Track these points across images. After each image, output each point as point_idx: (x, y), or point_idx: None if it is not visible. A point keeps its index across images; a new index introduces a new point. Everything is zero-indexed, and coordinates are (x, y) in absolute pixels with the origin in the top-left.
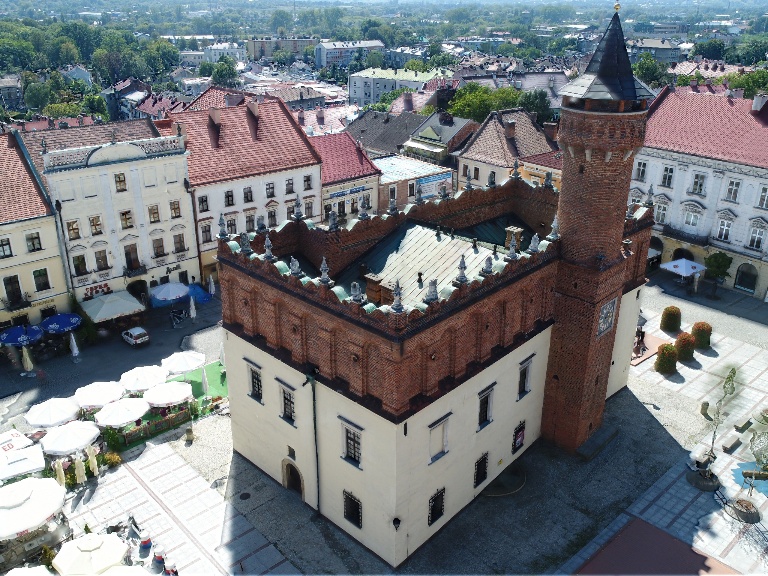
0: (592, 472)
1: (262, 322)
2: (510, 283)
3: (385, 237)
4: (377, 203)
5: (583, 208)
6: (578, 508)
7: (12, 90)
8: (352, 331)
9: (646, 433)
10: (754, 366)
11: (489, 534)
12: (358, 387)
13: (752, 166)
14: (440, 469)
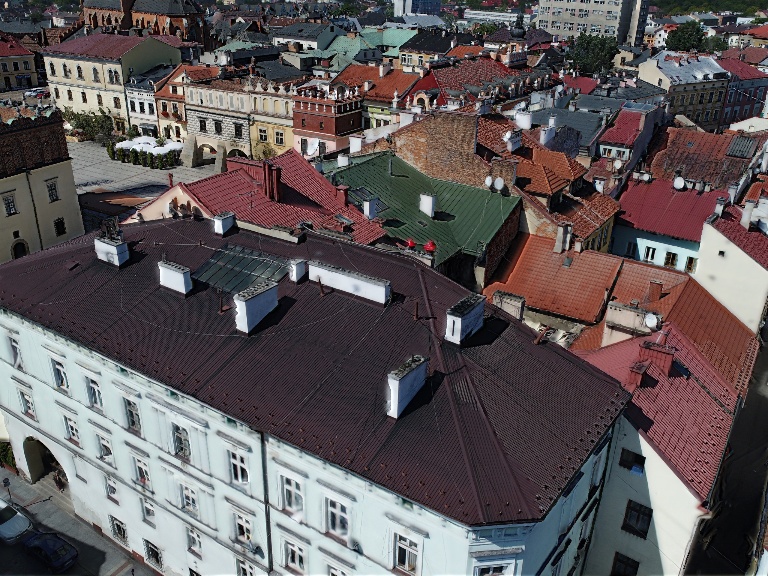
0: None
1: None
2: None
3: None
4: None
5: None
6: None
7: None
8: None
9: None
10: None
11: None
12: None
13: None
14: None
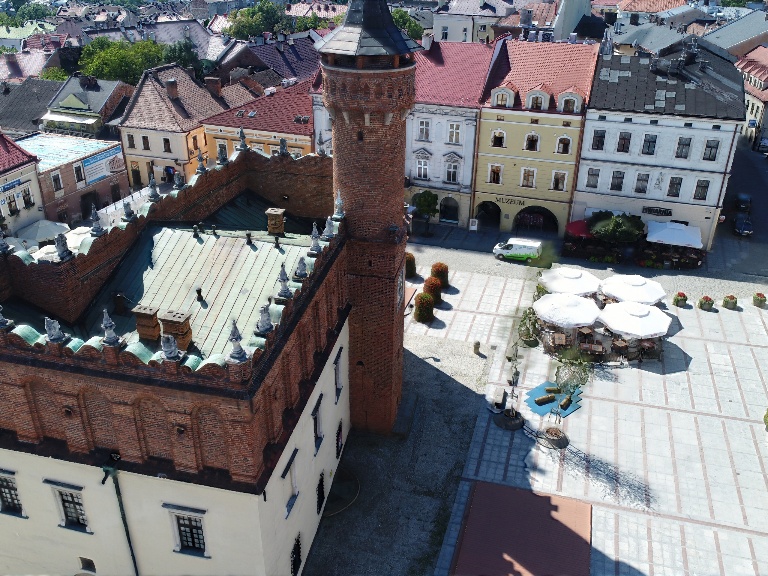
0: (415, 448)
1: (1, 412)
2: (321, 281)
3: (128, 251)
4: (40, 197)
5: (368, 179)
6: (421, 492)
7: None
8: (170, 397)
9: (441, 389)
10: (491, 294)
11: (352, 560)
12: (189, 463)
13: (439, 105)
14: (294, 516)
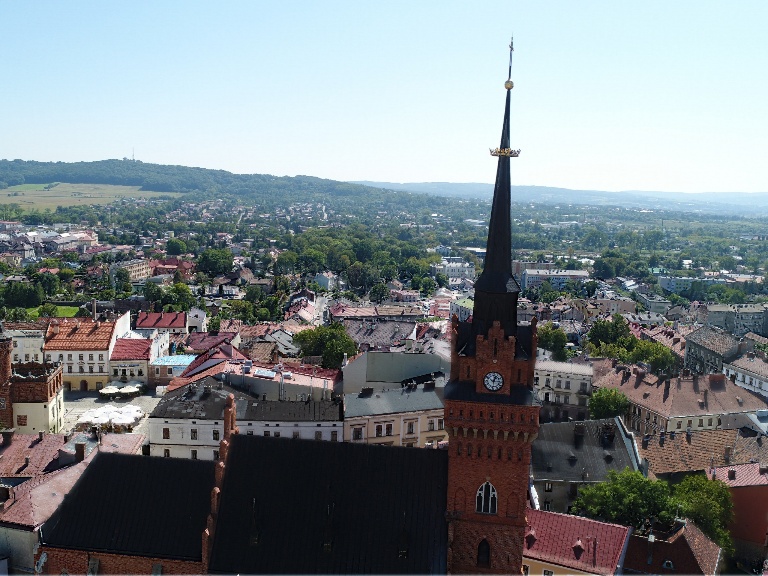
0: None
1: None
2: None
3: None
4: (148, 374)
5: None
6: None
7: (264, 286)
8: None
9: None
10: None
11: None
12: None
13: None
14: None
